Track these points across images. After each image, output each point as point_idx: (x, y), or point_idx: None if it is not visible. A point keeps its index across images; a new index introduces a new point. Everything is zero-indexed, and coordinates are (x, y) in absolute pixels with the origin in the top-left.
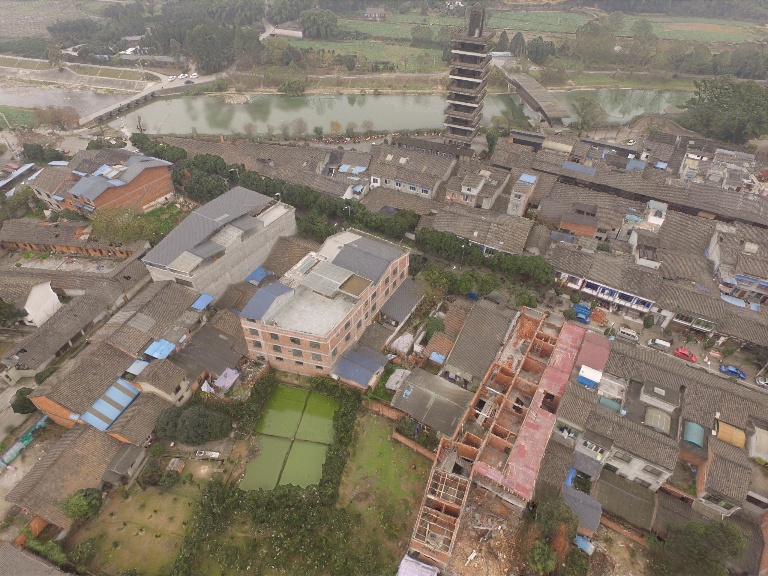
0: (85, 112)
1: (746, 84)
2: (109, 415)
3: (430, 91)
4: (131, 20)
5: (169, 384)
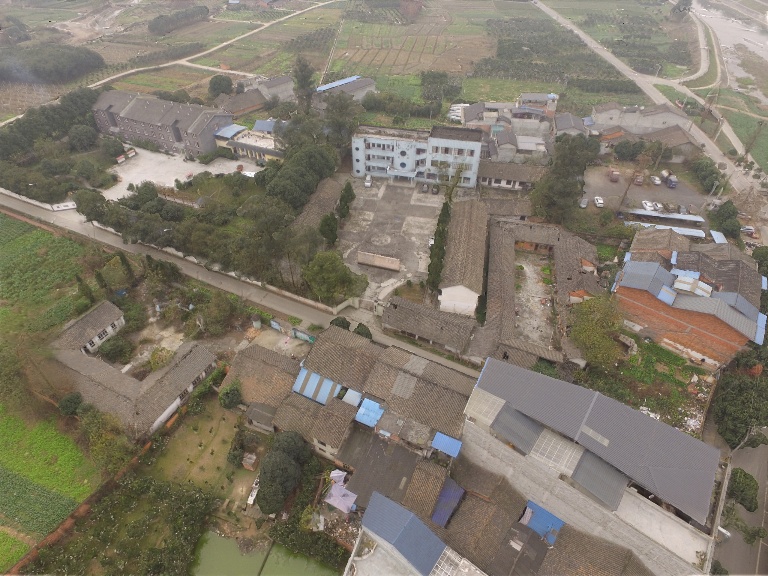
0: None
1: None
2: (307, 389)
3: None
4: None
5: (322, 432)
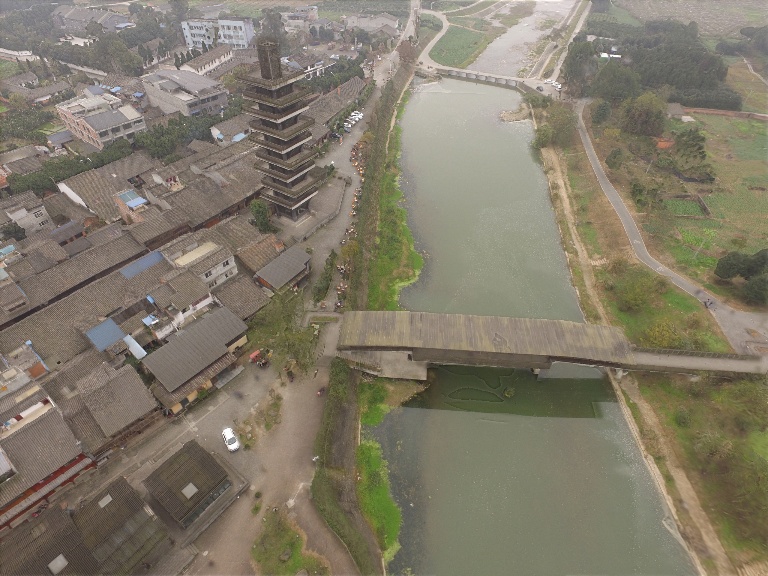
0: (474, 69)
1: None
2: None
3: (578, 249)
4: (682, 35)
5: None
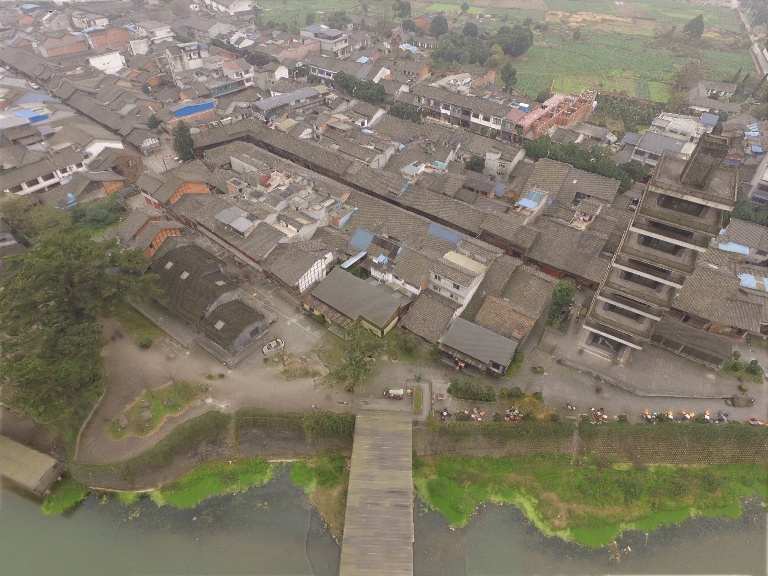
0: None
1: (62, 259)
2: None
3: None
4: None
5: None
